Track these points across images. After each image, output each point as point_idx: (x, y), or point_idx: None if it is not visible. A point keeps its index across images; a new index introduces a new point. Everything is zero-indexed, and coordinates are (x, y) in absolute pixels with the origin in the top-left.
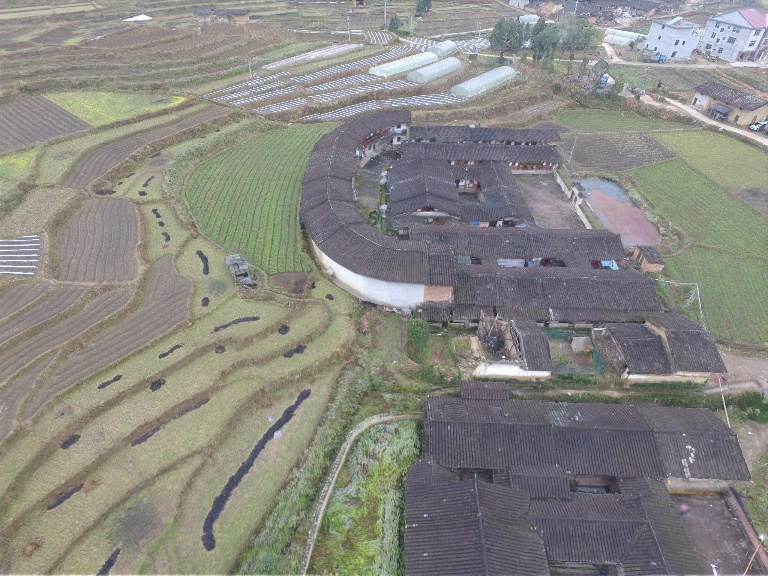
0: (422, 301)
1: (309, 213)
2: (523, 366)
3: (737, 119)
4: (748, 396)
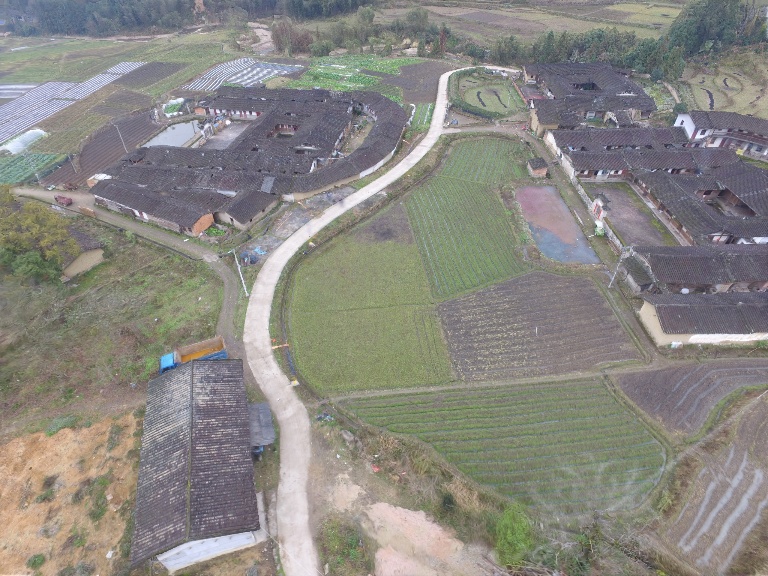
0: None
1: None
2: None
3: None
4: None
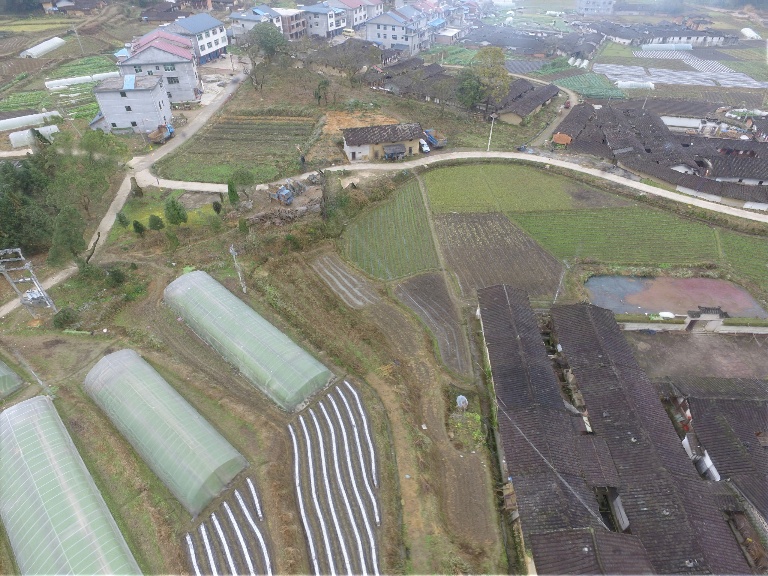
0: None
1: None
2: None
3: (411, 150)
4: None
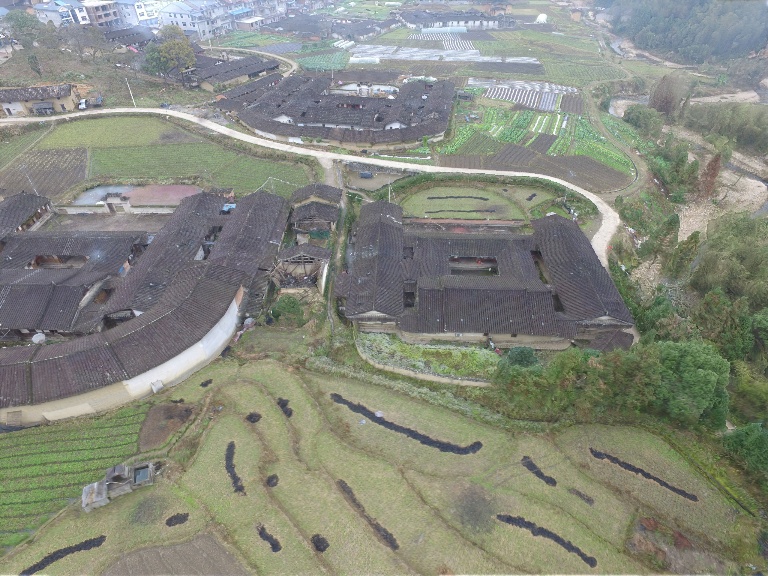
0: (237, 310)
1: (39, 392)
2: (327, 261)
3: (64, 107)
4: (348, 196)
